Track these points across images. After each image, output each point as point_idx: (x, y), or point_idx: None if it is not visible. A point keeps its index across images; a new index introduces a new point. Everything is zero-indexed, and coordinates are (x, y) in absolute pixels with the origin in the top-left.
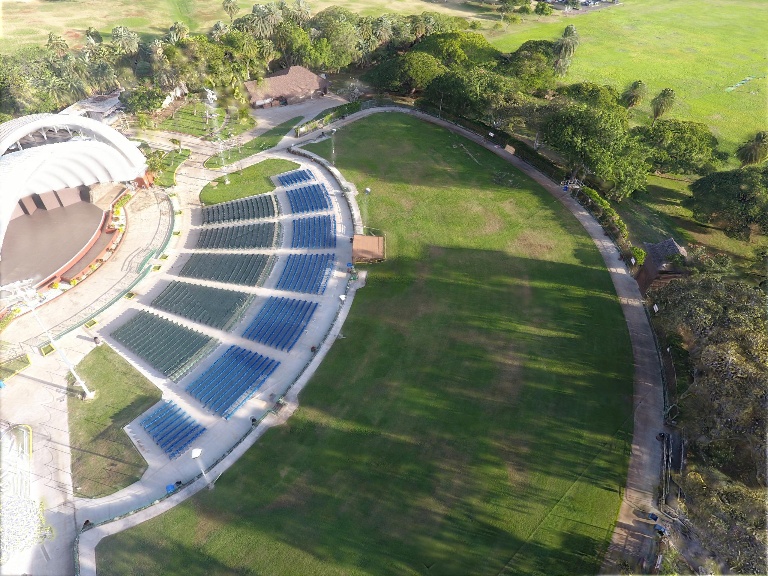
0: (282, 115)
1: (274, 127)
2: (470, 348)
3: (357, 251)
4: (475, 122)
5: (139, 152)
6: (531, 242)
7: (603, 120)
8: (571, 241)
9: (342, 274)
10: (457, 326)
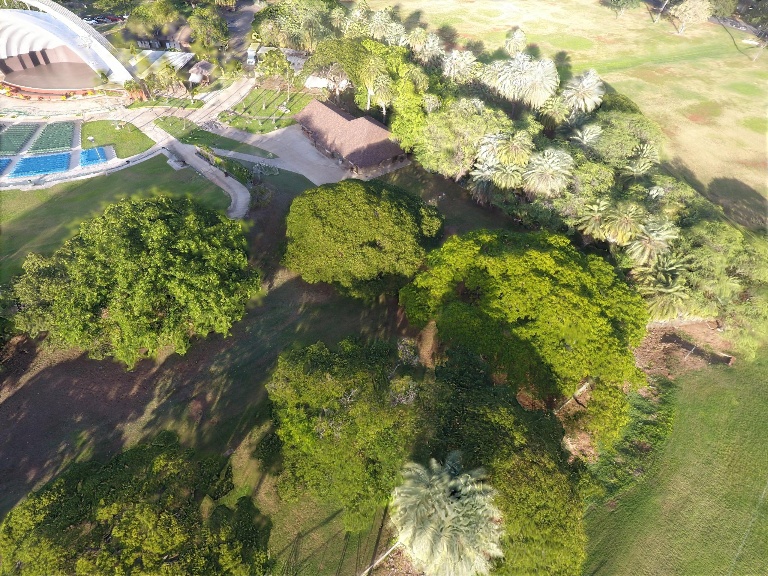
0: (284, 146)
1: (246, 143)
2: None
3: None
4: None
5: (123, 69)
6: None
7: None
8: None
9: None
10: None
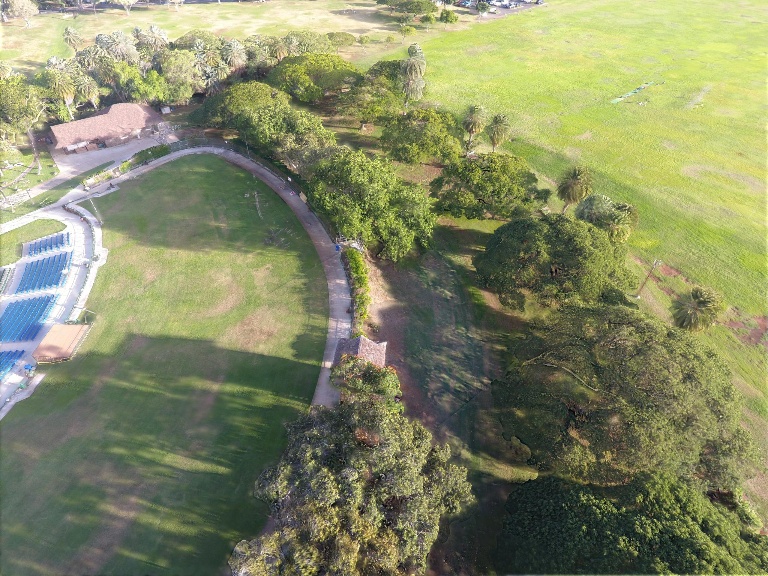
0: (93, 160)
1: (74, 177)
2: (88, 493)
3: (42, 348)
4: (276, 165)
5: None
6: (253, 327)
7: (352, 173)
8: (301, 323)
9: (17, 379)
10: (95, 457)
